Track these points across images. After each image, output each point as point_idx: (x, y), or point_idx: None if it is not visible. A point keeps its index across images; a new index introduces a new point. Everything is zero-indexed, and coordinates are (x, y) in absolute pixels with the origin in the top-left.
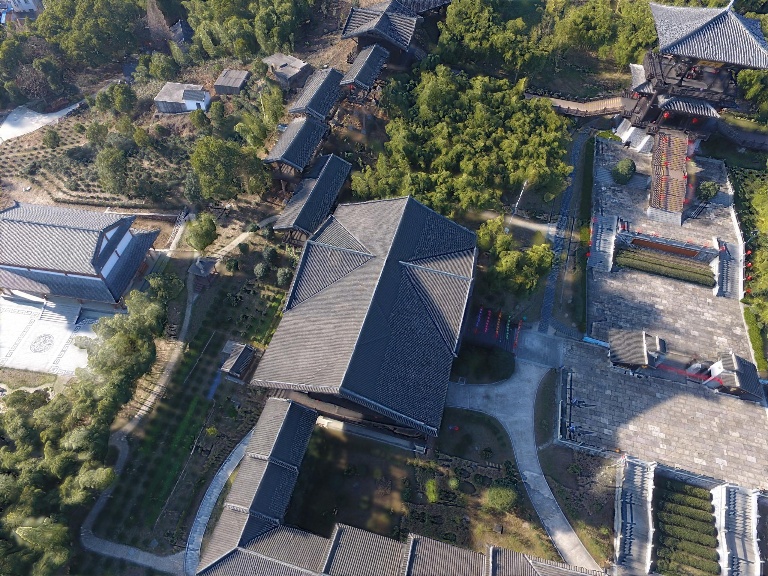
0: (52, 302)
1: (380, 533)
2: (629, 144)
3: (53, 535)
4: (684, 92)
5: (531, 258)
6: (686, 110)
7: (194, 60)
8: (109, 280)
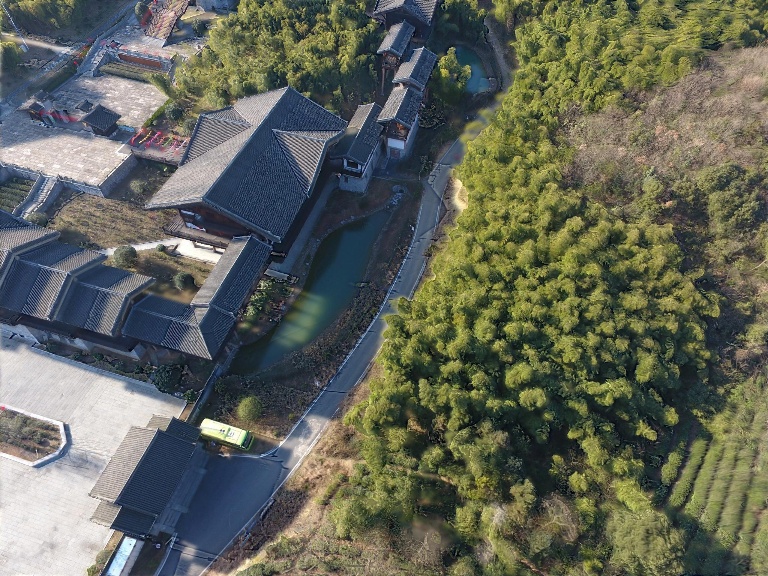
0: None
1: None
2: None
3: None
4: None
5: None
6: None
7: None
8: None
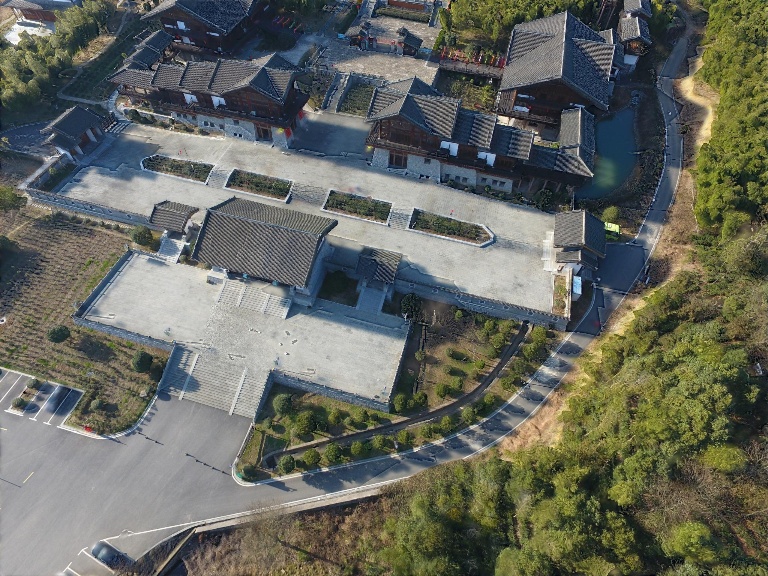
0: (45, 24)
1: None
2: None
3: (42, 67)
4: None
5: None
6: None
7: None
8: (75, 3)
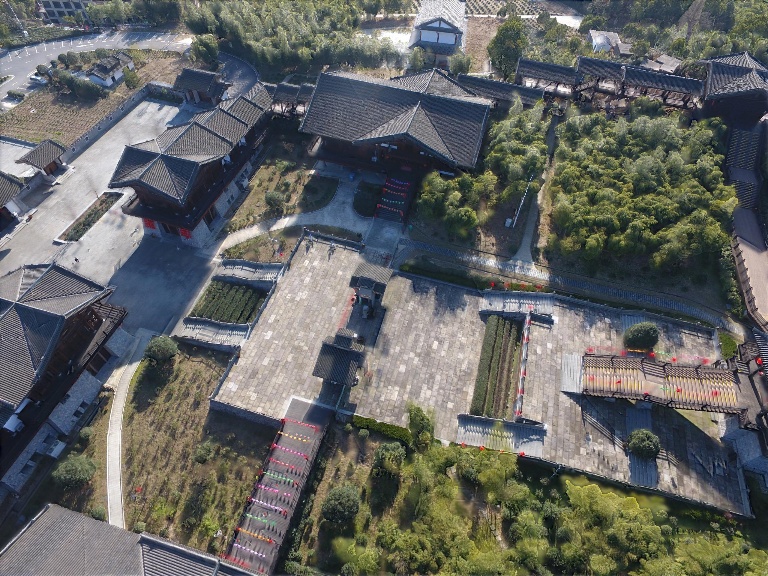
0: None
1: (269, 158)
2: (718, 366)
3: (284, 47)
4: None
5: (451, 195)
6: (767, 366)
7: (658, 40)
8: (421, 42)
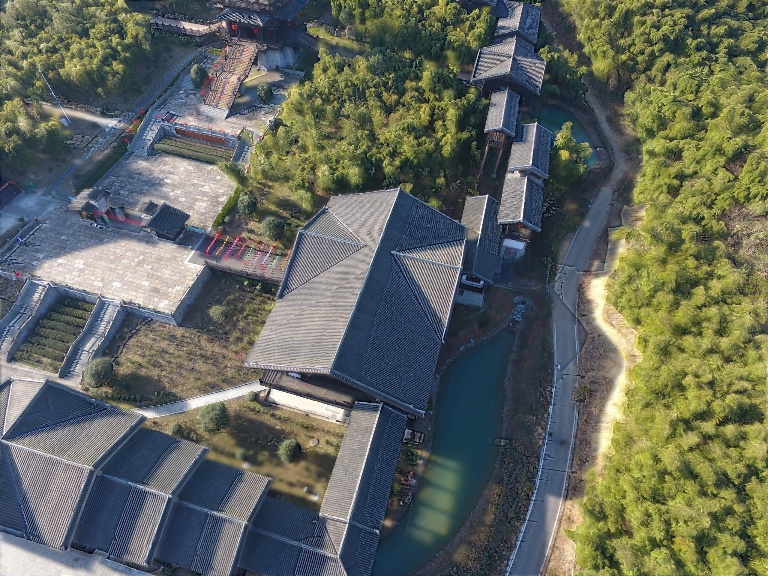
0: None
1: None
2: None
3: None
4: (231, 3)
5: (21, 128)
6: (238, 20)
7: None
8: None
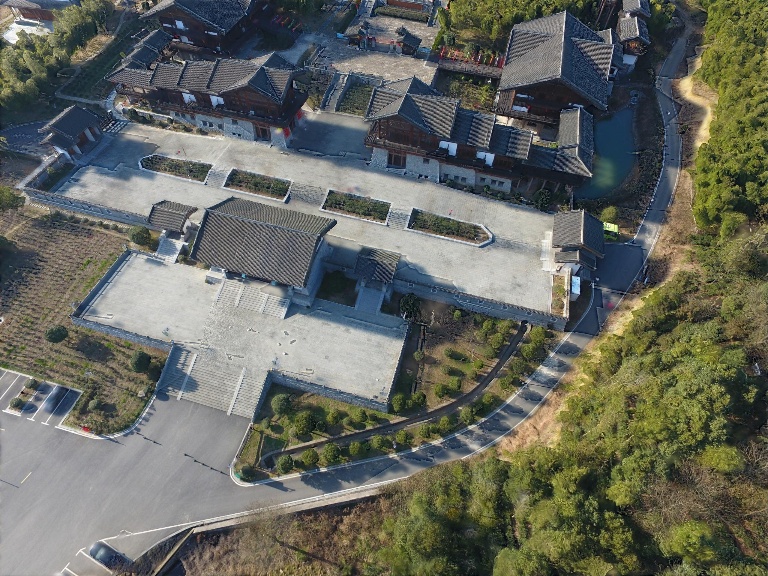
0: (43, 23)
1: None
2: None
3: (40, 67)
4: None
5: None
6: None
7: None
8: (74, 2)
